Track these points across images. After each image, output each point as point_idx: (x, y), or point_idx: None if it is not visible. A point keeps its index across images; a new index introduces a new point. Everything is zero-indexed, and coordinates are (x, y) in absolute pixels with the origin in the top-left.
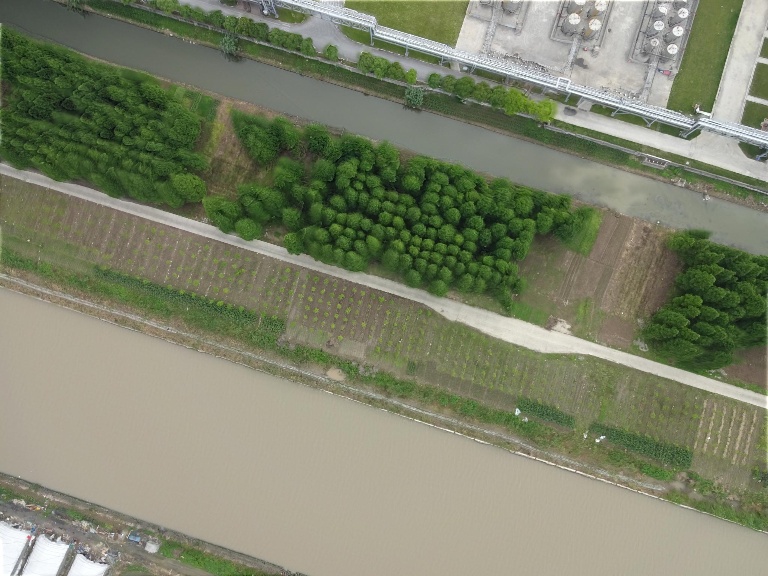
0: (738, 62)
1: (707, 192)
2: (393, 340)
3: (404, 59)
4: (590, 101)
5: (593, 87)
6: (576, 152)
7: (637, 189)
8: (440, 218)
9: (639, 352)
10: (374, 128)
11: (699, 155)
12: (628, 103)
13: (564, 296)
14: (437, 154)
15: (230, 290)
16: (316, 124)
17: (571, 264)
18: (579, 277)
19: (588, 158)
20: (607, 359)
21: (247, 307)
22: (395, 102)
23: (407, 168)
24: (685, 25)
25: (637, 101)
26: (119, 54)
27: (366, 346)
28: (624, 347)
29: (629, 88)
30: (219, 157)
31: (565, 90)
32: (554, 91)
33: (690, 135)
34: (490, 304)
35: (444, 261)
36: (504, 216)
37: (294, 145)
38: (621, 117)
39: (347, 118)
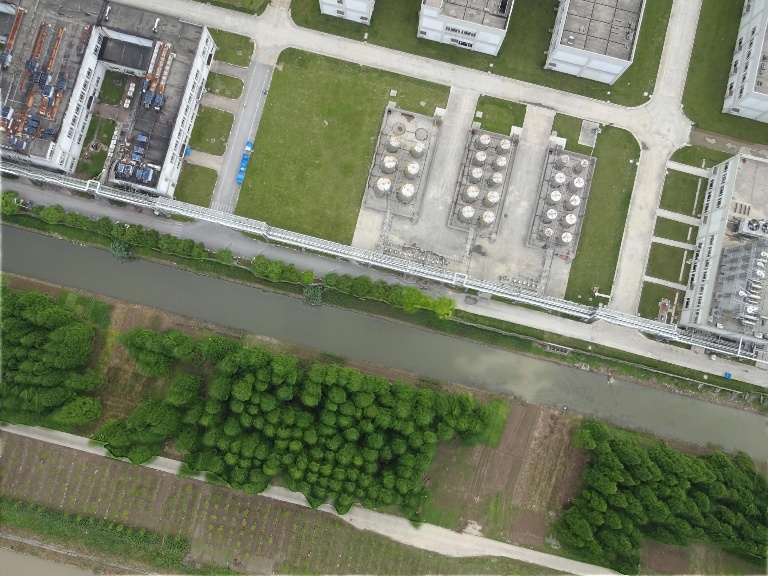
0: (633, 242)
1: (611, 375)
2: (302, 554)
3: (301, 254)
4: (489, 293)
5: (490, 281)
6: (479, 341)
7: (542, 375)
8: (338, 439)
9: (551, 550)
10: (274, 326)
11: (601, 339)
12: (526, 295)
13: (475, 492)
14: (340, 350)
15: (130, 510)
16: (214, 325)
17: (480, 457)
18: (489, 471)
19: (492, 346)
20: (520, 559)
21: (149, 528)
22: (295, 297)
23: (304, 382)
24: (578, 213)
25: (534, 293)
26: (6, 261)
27: (274, 562)
28: (536, 545)
29: (528, 274)
30: (115, 365)
31: (462, 285)
32: (452, 286)
33: (591, 319)
34: (399, 509)
35: (343, 487)
36: (403, 431)
37: (193, 348)
38: (521, 305)
39: (246, 318)
